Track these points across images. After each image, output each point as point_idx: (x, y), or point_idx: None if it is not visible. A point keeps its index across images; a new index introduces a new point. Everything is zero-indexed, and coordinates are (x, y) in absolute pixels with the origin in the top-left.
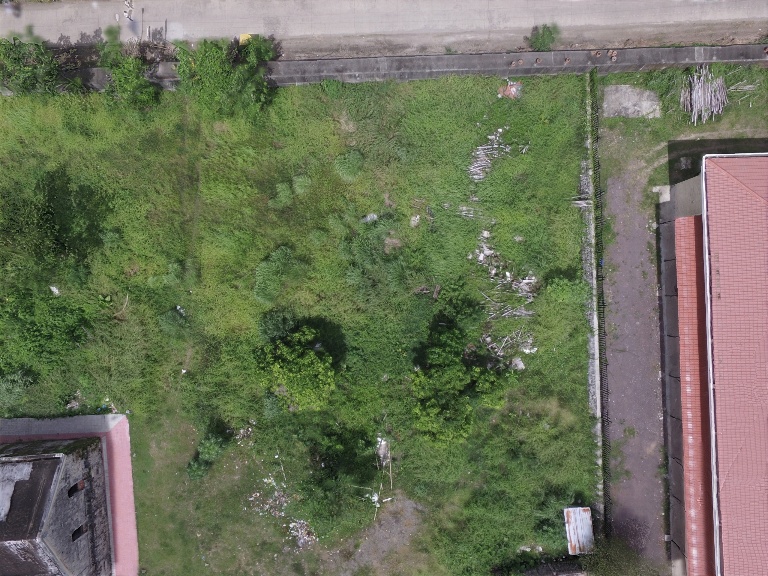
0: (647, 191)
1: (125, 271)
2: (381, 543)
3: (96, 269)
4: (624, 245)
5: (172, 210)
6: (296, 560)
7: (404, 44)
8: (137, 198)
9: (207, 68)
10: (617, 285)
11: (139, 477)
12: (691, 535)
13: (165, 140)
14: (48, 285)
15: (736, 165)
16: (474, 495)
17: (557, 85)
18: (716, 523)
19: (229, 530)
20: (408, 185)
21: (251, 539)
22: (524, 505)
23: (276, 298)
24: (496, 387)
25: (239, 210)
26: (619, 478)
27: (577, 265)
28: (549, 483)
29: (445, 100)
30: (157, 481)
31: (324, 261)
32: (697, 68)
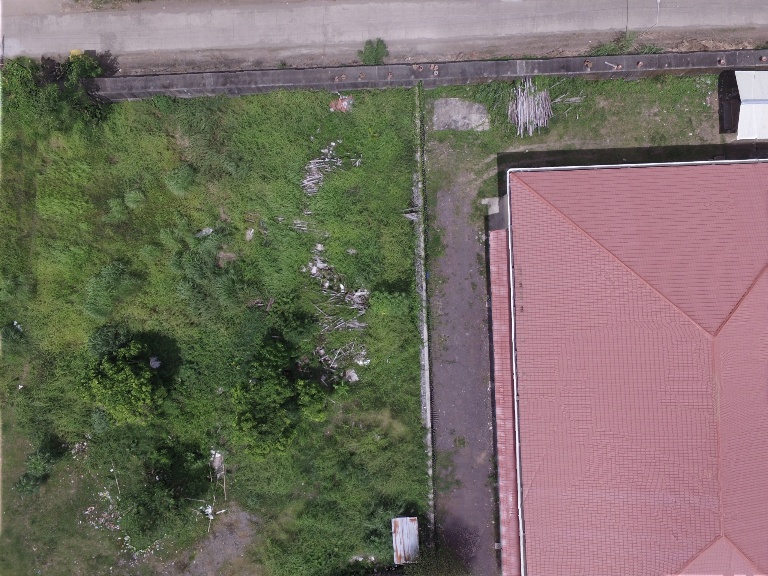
0: (476, 203)
1: None
2: (216, 555)
3: None
4: (453, 257)
5: (10, 226)
6: (131, 573)
7: (240, 58)
8: None
9: (16, 87)
10: (447, 297)
11: None
12: (505, 544)
13: (1, 156)
14: None
15: (539, 179)
16: (306, 506)
17: (386, 99)
18: (520, 533)
19: (65, 544)
20: (240, 199)
21: (87, 552)
22: (354, 515)
23: (110, 313)
24: (314, 400)
25: (76, 225)
26: (450, 487)
27: (411, 277)
28: (378, 493)
29: (276, 114)
30: None
31: (159, 276)
32: (522, 81)
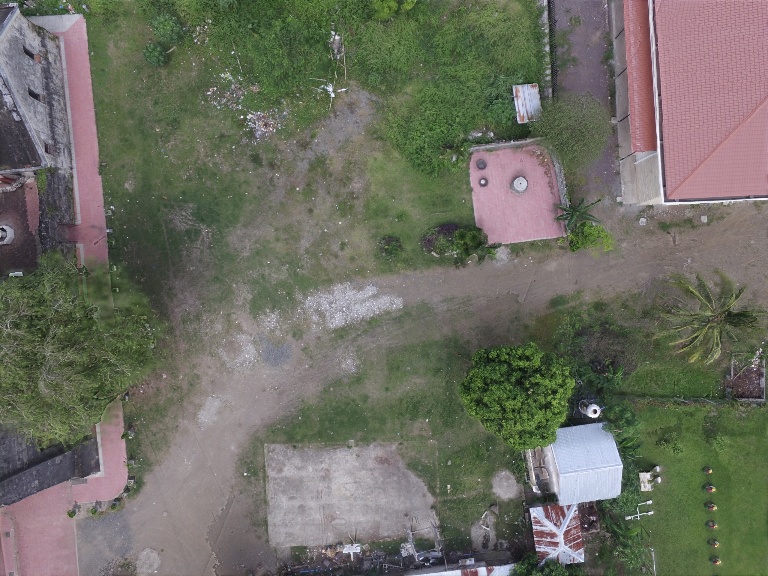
0: None
1: None
2: (337, 133)
3: None
4: None
5: None
6: (254, 151)
7: None
8: None
9: None
10: None
11: (97, 75)
12: (632, 80)
13: None
14: None
15: None
16: (426, 83)
17: None
18: (653, 46)
19: (187, 123)
20: None
21: (209, 132)
22: (474, 86)
23: None
24: None
25: None
26: (566, 64)
27: None
28: (498, 65)
29: None
30: (115, 79)
31: None
32: None
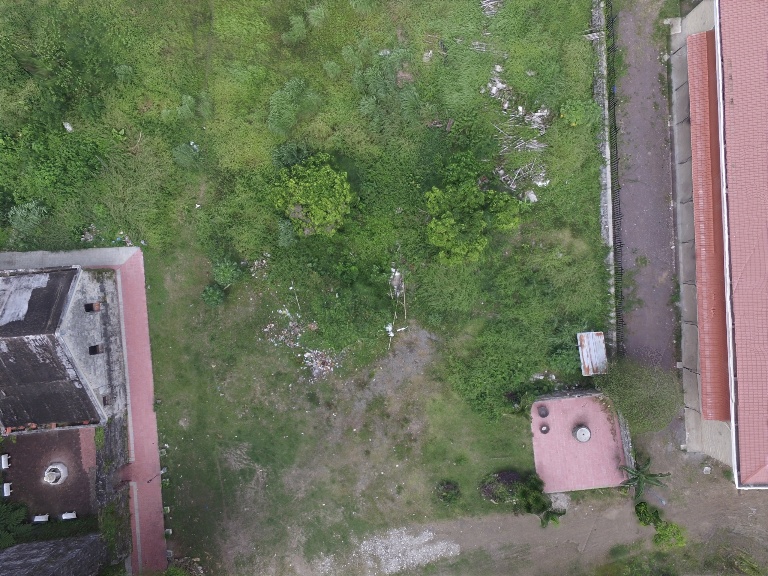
0: (658, 23)
1: (138, 108)
2: (395, 373)
3: (110, 103)
4: (636, 76)
5: (185, 48)
6: (311, 390)
7: None
8: (150, 35)
9: None
10: (629, 116)
11: (154, 309)
12: (704, 346)
13: None
14: (61, 120)
15: None
16: (488, 324)
17: None
18: (729, 325)
19: (244, 361)
20: (421, 18)
21: (266, 369)
22: (537, 331)
23: (290, 131)
24: (510, 203)
25: (252, 47)
26: (631, 306)
27: None
28: (562, 309)
29: None
30: (172, 313)
31: (337, 95)
32: None
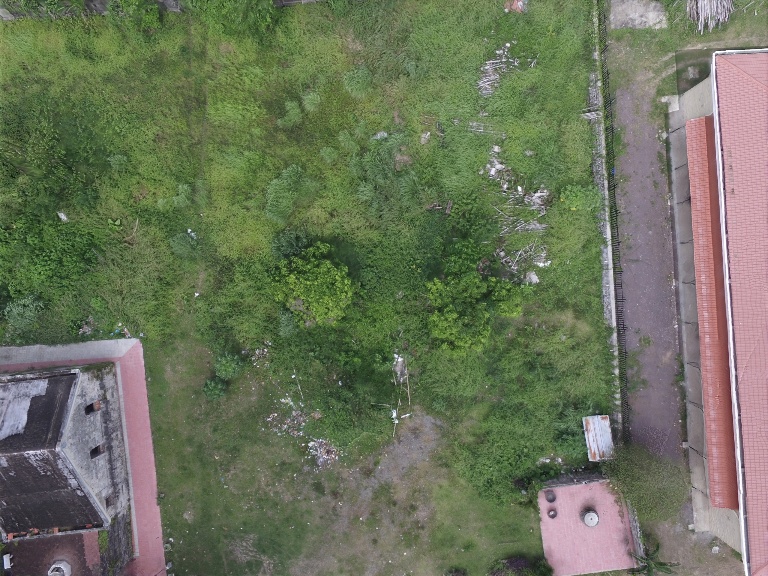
0: (656, 101)
1: (134, 196)
2: (401, 459)
3: (105, 193)
4: (635, 155)
5: (180, 134)
6: (316, 479)
7: None
8: (144, 122)
9: None
10: (629, 195)
11: (155, 401)
12: (710, 433)
13: (171, 63)
14: (56, 211)
15: (746, 61)
16: (492, 408)
17: None
18: (735, 416)
19: (247, 451)
20: (418, 101)
21: (270, 460)
22: (542, 415)
23: (288, 217)
24: (513, 293)
25: (248, 131)
26: (636, 387)
27: (588, 178)
28: (567, 393)
29: (453, 15)
30: (173, 405)
31: (335, 180)
32: None
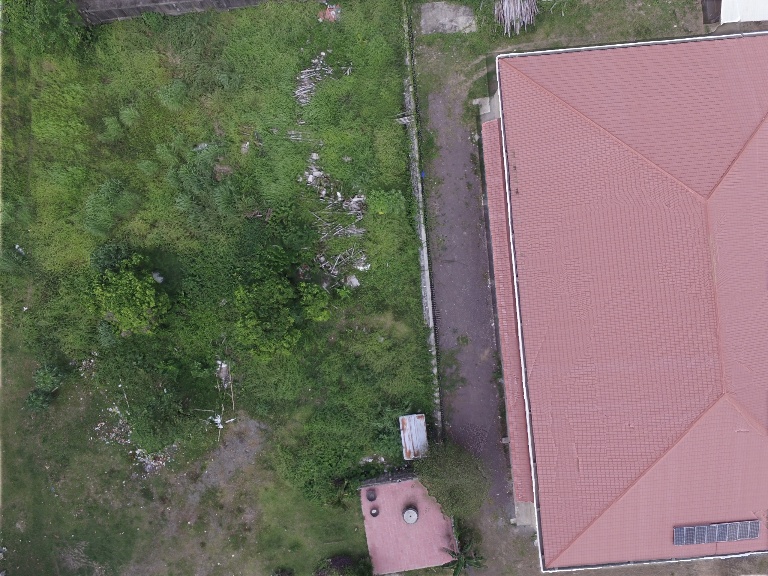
0: (467, 104)
1: None
2: (227, 463)
3: None
4: (447, 158)
5: (7, 152)
6: (144, 485)
7: None
8: None
9: None
10: (443, 197)
11: None
12: (512, 429)
13: None
14: None
15: (527, 63)
16: (314, 410)
17: (373, 5)
18: (526, 412)
19: (77, 460)
20: (233, 112)
21: (99, 468)
22: (361, 416)
23: (111, 230)
24: (317, 298)
25: (72, 147)
26: (455, 385)
27: (407, 182)
28: (385, 393)
29: (265, 26)
30: (3, 417)
31: (157, 192)
32: None
